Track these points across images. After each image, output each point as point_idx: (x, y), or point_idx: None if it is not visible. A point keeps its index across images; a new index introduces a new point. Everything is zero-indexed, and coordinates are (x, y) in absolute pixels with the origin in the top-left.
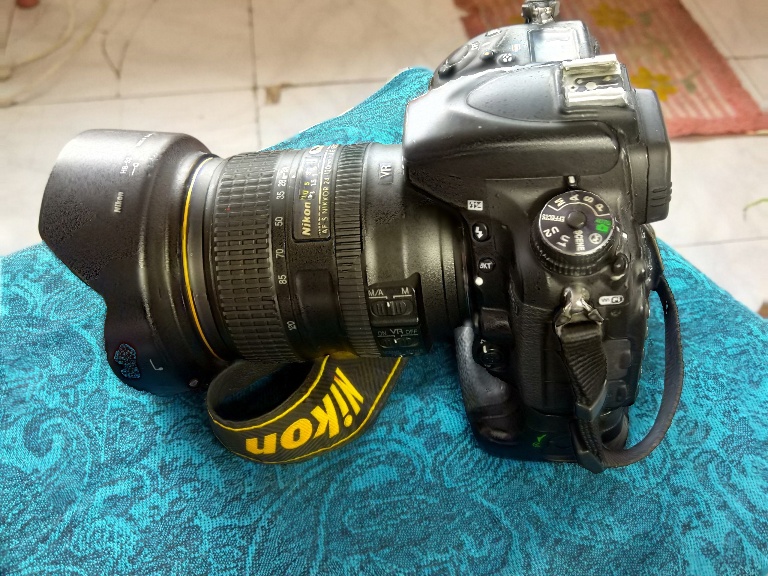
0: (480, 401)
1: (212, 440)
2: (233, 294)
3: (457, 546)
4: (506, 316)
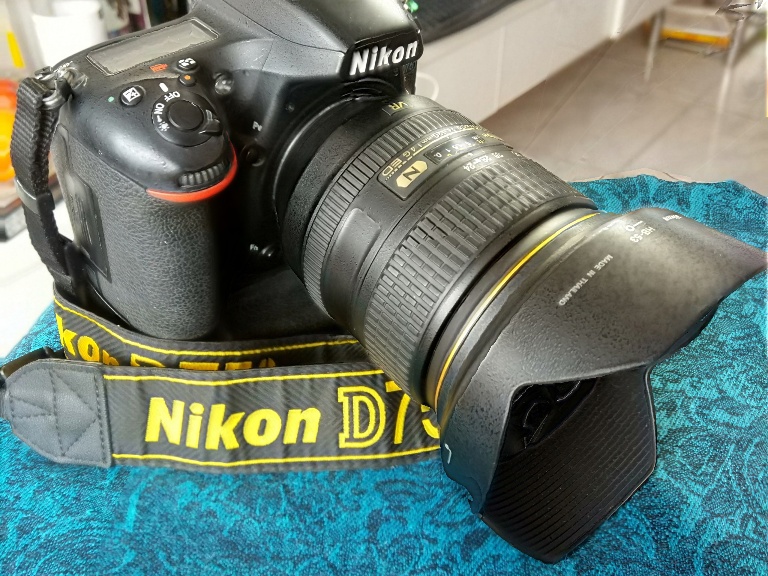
0: None
1: None
2: None
3: None
4: None
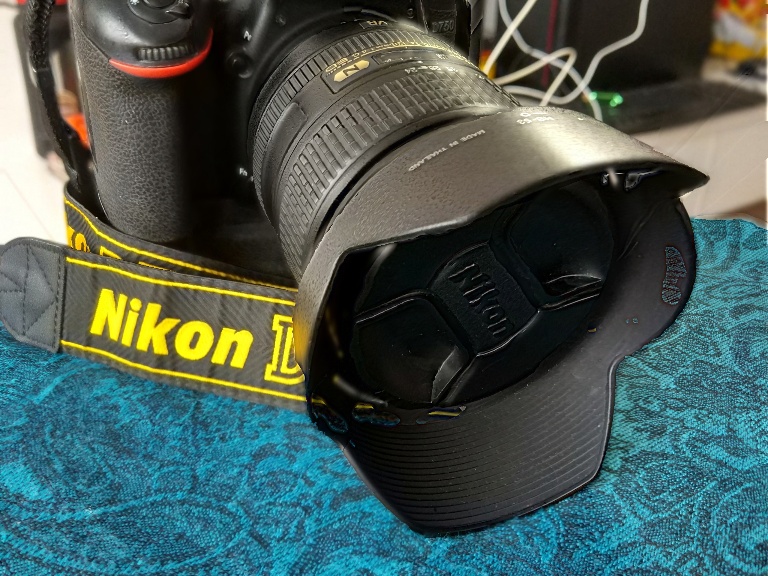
0: None
1: None
2: None
3: None
4: None
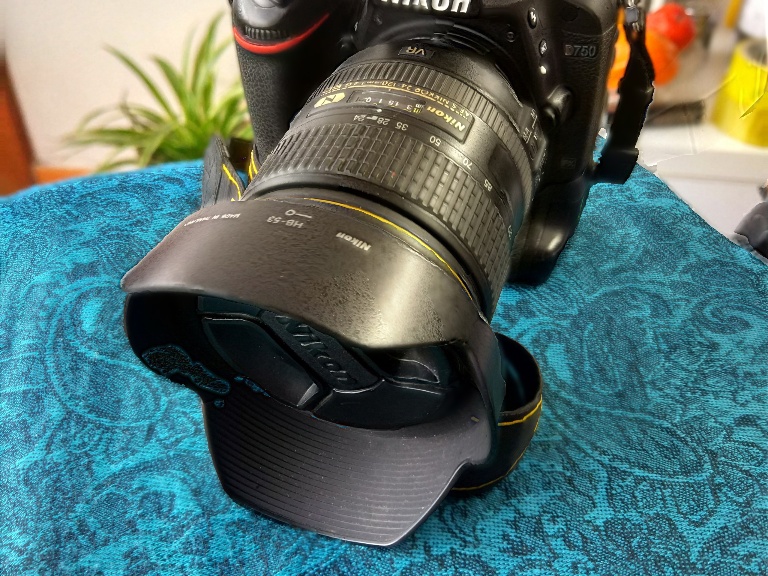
0: (519, 242)
1: (479, 498)
2: (479, 240)
3: (639, 322)
4: (559, 91)
